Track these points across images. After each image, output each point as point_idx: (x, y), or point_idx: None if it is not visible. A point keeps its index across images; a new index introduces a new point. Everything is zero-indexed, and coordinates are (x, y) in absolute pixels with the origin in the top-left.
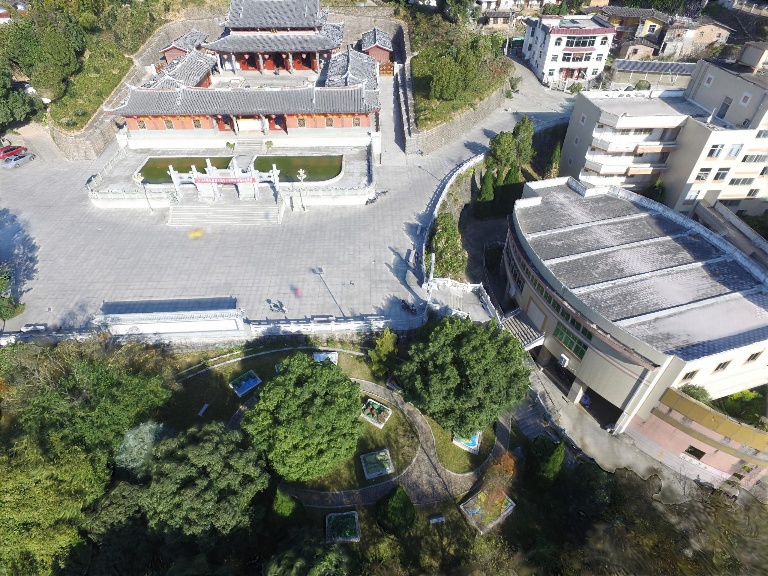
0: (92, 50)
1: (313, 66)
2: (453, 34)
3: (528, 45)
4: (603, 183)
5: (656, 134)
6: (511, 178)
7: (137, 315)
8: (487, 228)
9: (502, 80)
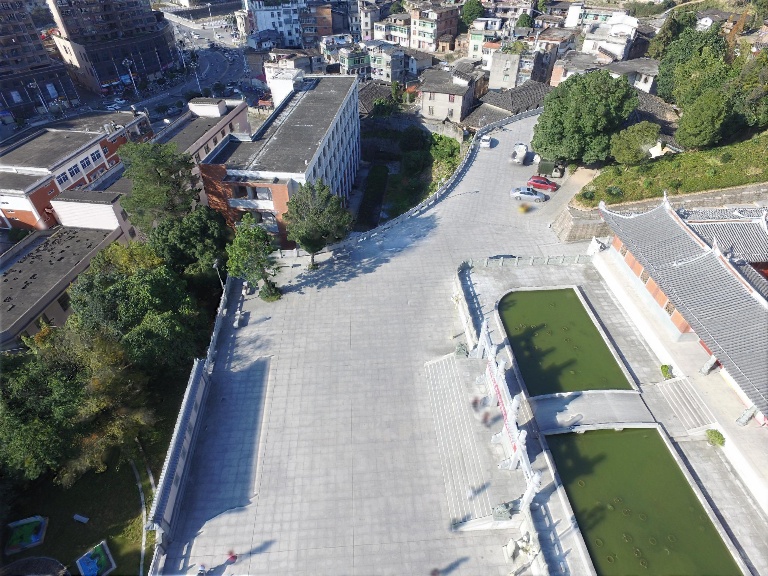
0: None
1: None
2: None
3: None
4: None
5: None
6: None
7: None
8: None
9: None
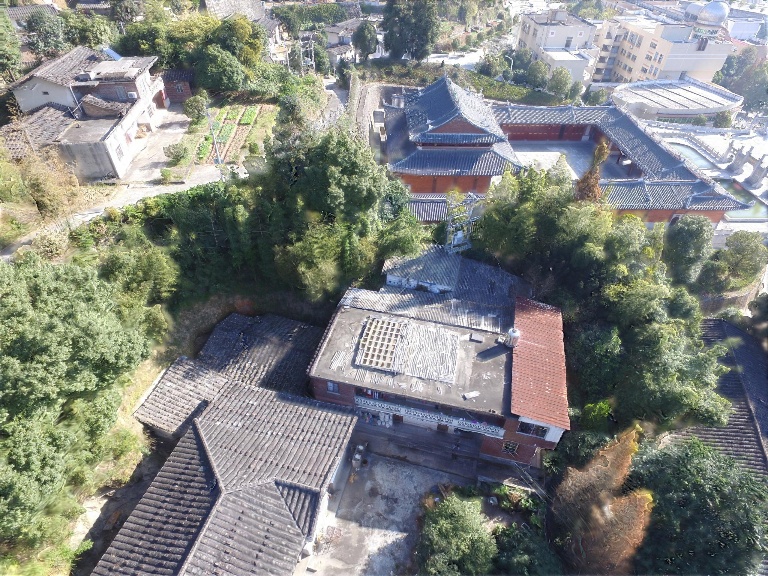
0: None
1: None
2: None
3: None
4: None
5: None
6: None
7: None
8: None
9: None
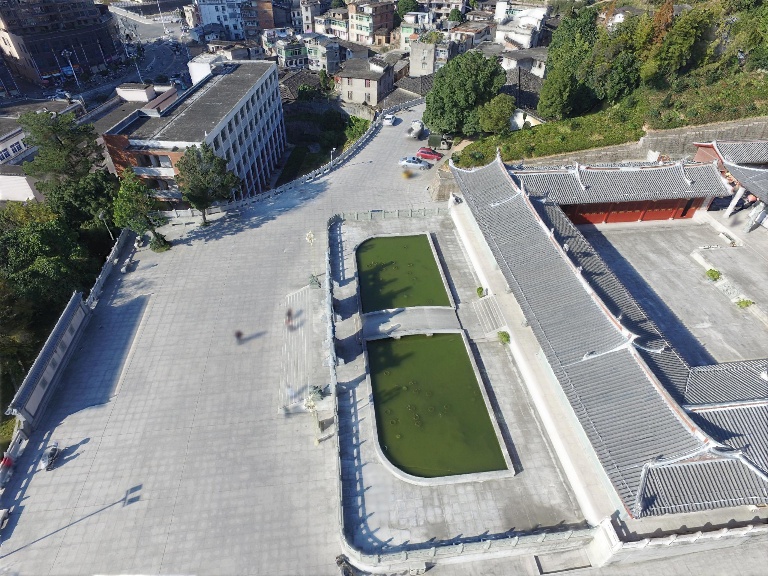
0: (621, 105)
1: None
2: None
3: None
4: None
5: None
6: None
7: None
8: None
9: None
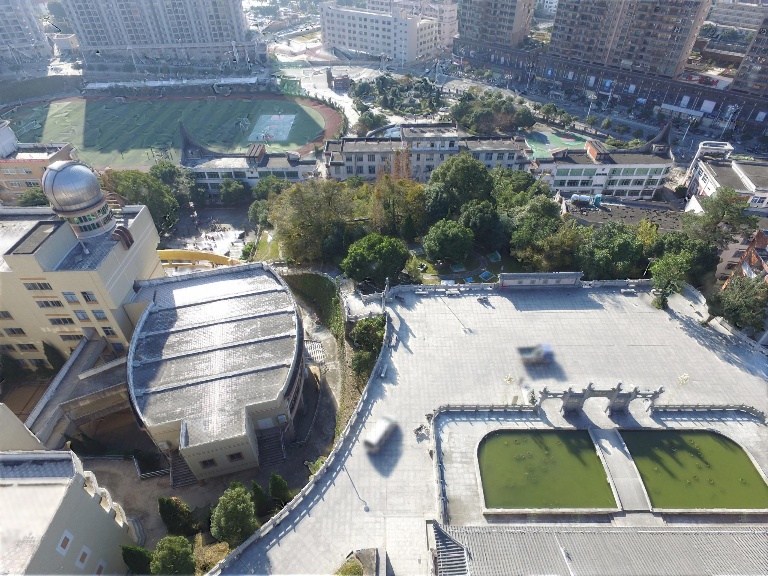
0: None
1: None
2: None
3: None
4: None
5: None
6: None
7: (558, 273)
8: None
9: None
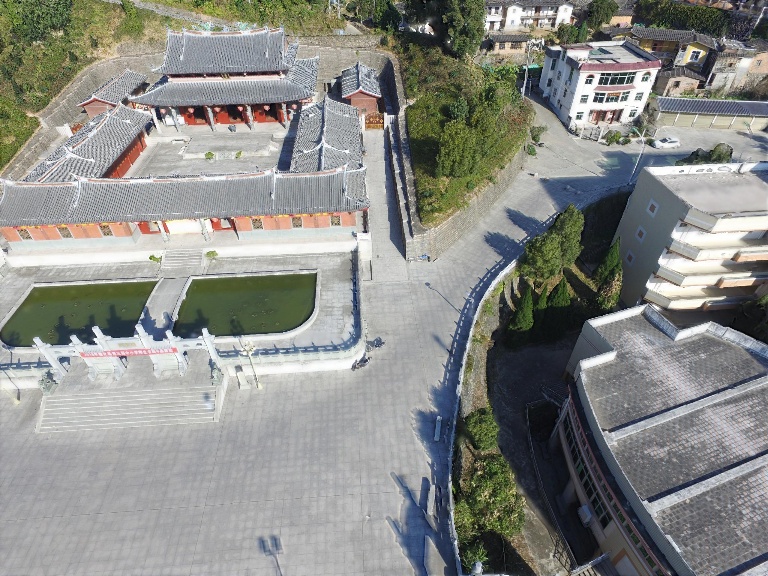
0: None
1: (280, 117)
2: (459, 75)
3: (547, 80)
4: (678, 290)
5: (759, 231)
6: (558, 299)
7: None
8: (524, 365)
9: (523, 134)
